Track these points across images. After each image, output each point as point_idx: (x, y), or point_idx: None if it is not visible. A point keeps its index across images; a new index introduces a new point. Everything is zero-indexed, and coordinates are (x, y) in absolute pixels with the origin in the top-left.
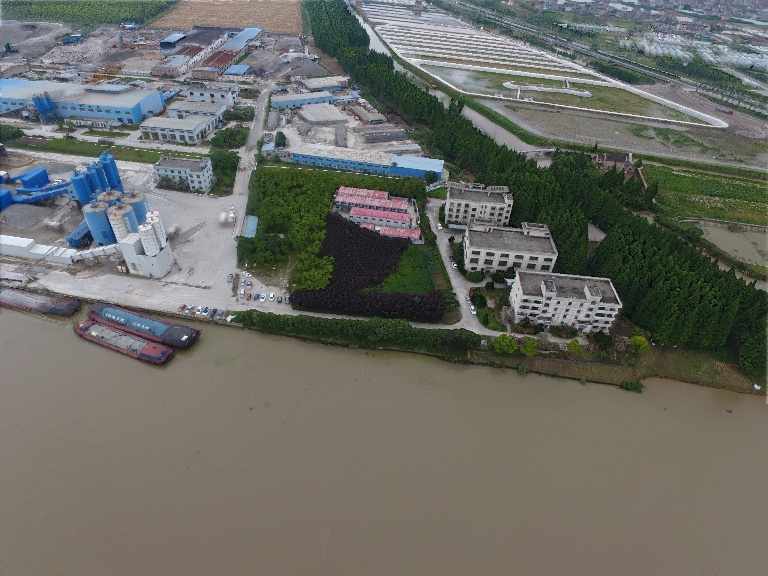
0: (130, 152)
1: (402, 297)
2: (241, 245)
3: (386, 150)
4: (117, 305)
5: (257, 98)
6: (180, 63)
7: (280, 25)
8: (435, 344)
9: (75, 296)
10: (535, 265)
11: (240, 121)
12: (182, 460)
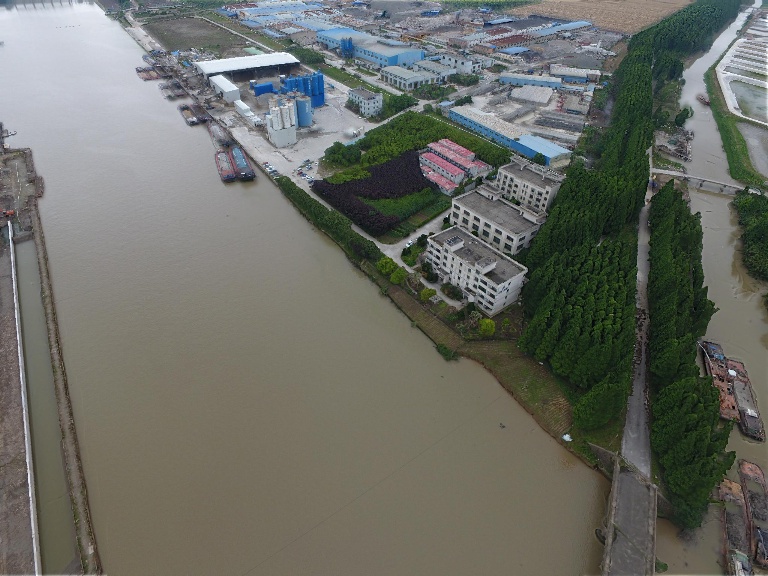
0: (360, 84)
1: (367, 208)
2: (332, 146)
3: (538, 132)
4: (244, 150)
5: (499, 73)
6: (474, 38)
7: (625, 24)
8: (348, 242)
9: (236, 139)
10: (500, 240)
11: (459, 85)
12: (177, 217)
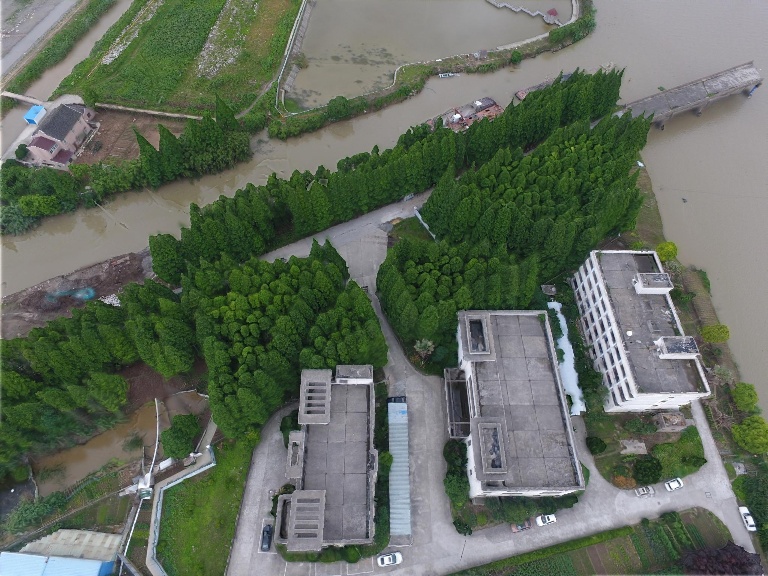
0: None
1: None
2: None
3: None
4: None
5: None
6: None
7: None
8: None
9: None
10: None
11: None
12: None
